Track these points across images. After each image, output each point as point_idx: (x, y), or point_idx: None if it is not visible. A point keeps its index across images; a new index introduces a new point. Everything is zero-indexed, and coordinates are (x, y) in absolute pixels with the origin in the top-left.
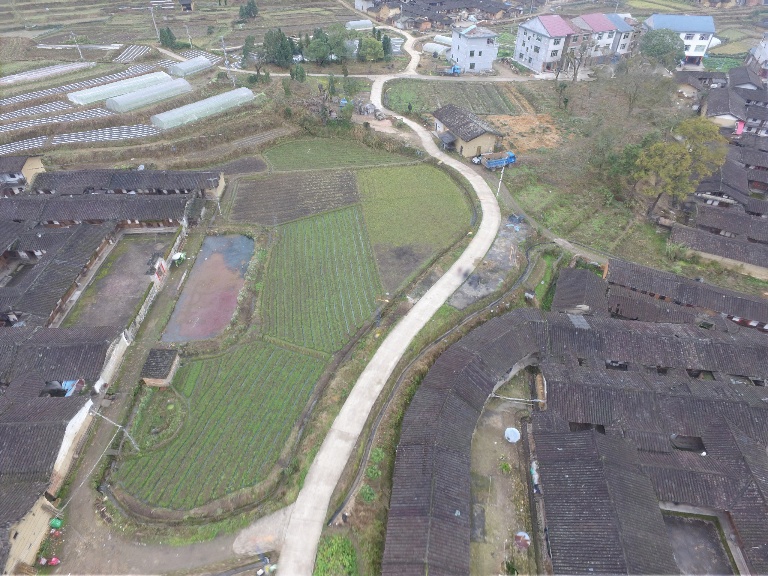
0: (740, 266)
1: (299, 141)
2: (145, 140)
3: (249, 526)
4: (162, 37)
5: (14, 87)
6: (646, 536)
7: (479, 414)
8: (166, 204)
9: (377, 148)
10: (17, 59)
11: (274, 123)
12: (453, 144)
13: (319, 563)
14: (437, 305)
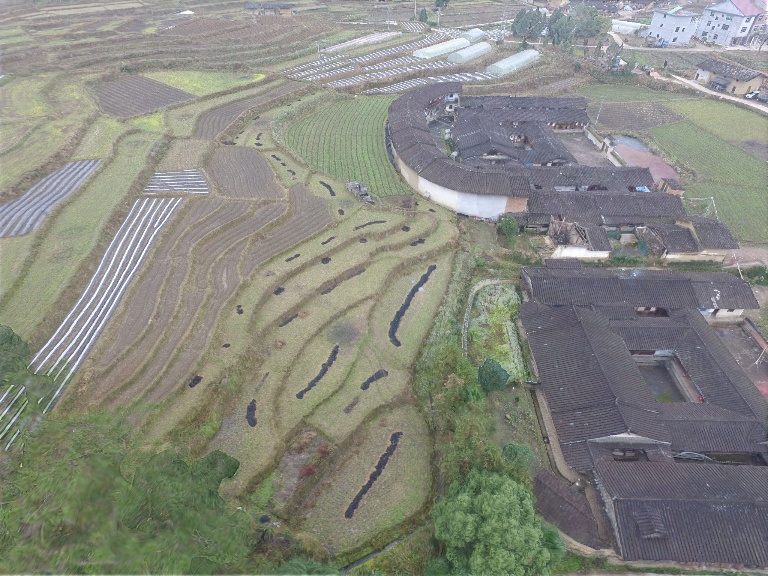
0: None
1: (594, 86)
2: (495, 81)
3: None
4: (422, 16)
5: (366, 47)
6: None
7: None
8: (574, 113)
9: (662, 90)
10: (342, 29)
11: (569, 74)
12: (724, 86)
13: None
14: None
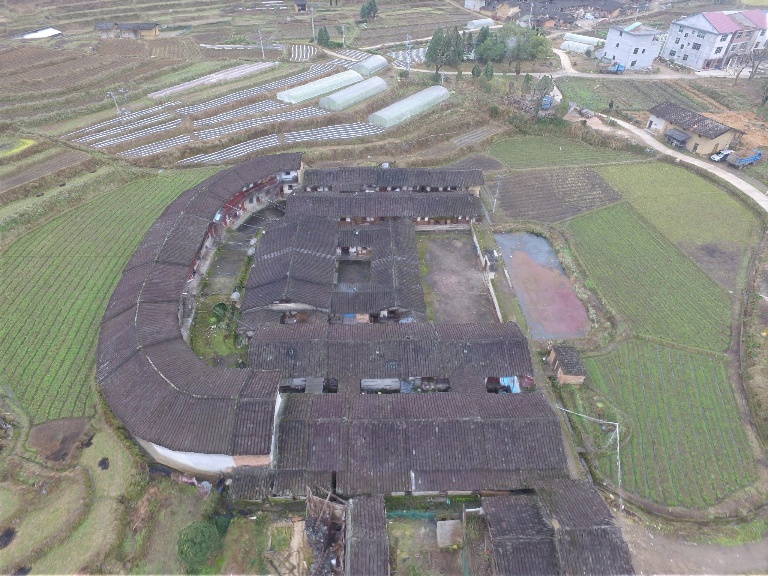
0: None
1: (513, 139)
2: (374, 138)
3: None
4: (321, 37)
5: (219, 86)
6: None
7: None
8: (455, 201)
9: (600, 146)
10: (202, 59)
11: (482, 121)
12: (683, 141)
13: None
14: None
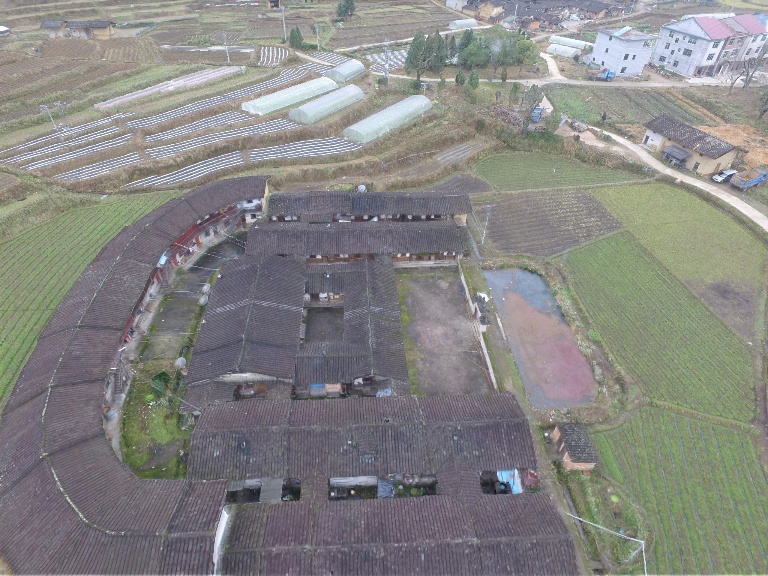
0: None
1: (501, 155)
2: (350, 156)
3: None
4: (293, 38)
5: (177, 95)
6: None
7: None
8: (440, 234)
9: (595, 164)
10: (160, 62)
11: (467, 135)
12: (682, 160)
13: None
14: None
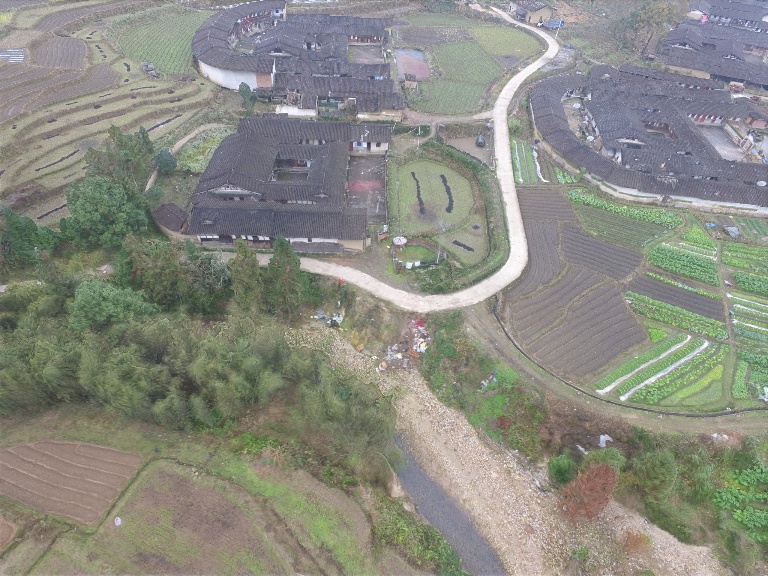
0: (690, 72)
1: (422, 14)
2: (332, 5)
3: (477, 114)
4: None
5: None
6: (633, 119)
7: (562, 96)
8: (373, 28)
9: (475, 18)
10: None
11: (404, 3)
12: (524, 16)
13: (509, 120)
14: (534, 70)
